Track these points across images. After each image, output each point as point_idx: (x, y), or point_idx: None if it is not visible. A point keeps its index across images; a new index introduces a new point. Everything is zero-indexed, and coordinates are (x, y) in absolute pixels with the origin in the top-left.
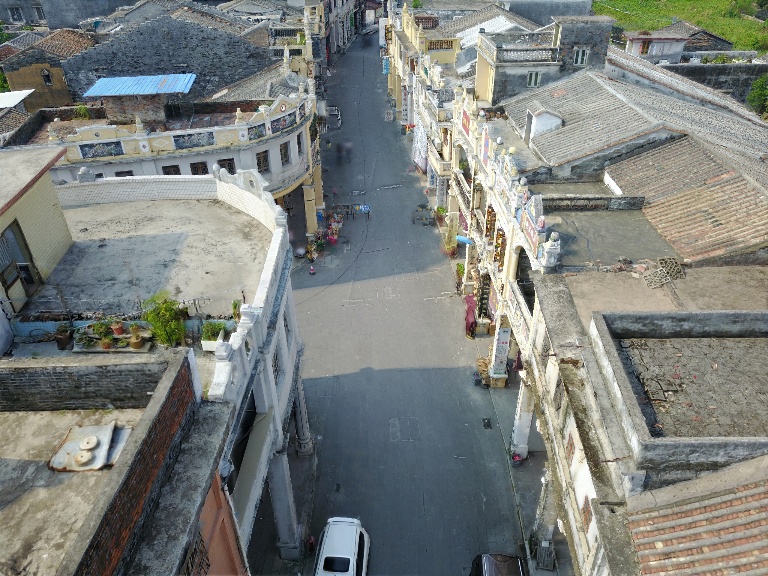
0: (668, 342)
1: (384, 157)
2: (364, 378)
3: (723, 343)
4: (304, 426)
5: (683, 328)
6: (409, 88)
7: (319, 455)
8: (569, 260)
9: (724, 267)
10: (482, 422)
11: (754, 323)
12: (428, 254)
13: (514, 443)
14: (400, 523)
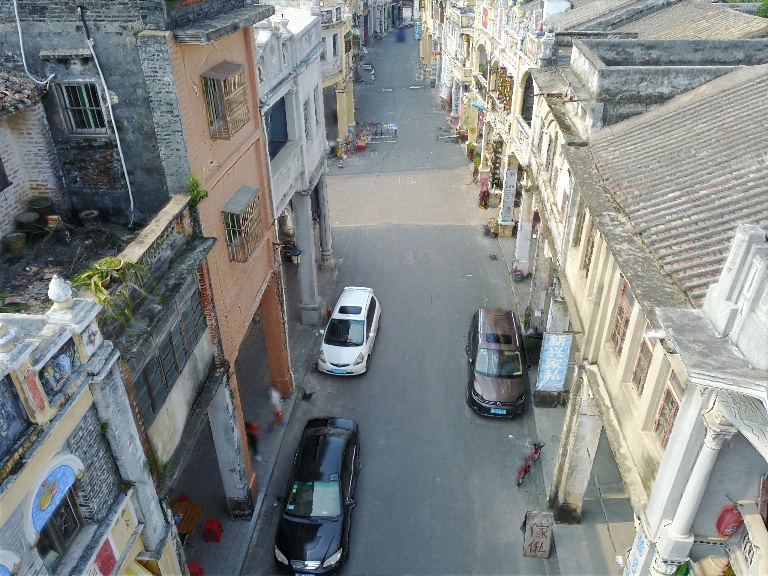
0: None
1: (413, 101)
2: (383, 228)
3: None
4: (327, 236)
5: (651, 57)
6: (438, 39)
7: (339, 270)
8: None
9: None
10: (489, 256)
11: (713, 52)
12: (449, 159)
13: (516, 259)
14: (409, 309)
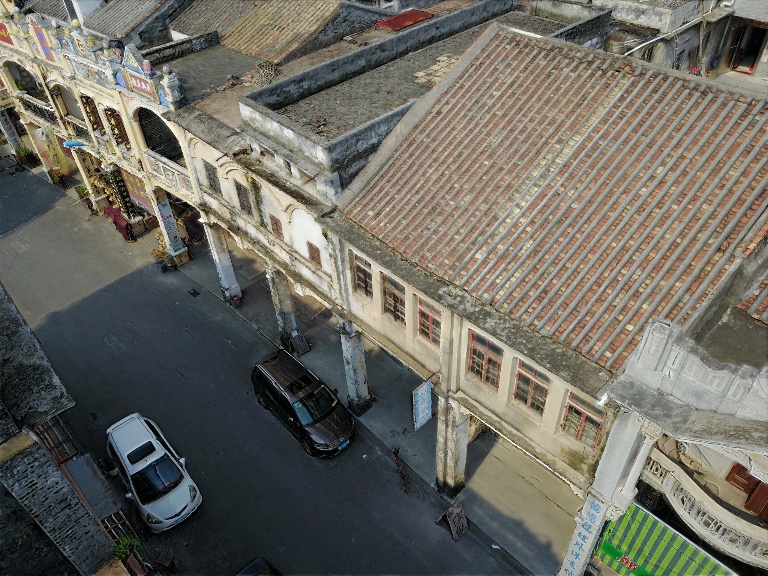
0: (300, 103)
1: None
2: (50, 324)
3: (334, 89)
4: None
5: (304, 88)
6: None
7: None
8: (189, 95)
9: (303, 57)
10: (189, 294)
11: (345, 67)
12: (36, 197)
13: (226, 288)
14: (173, 401)
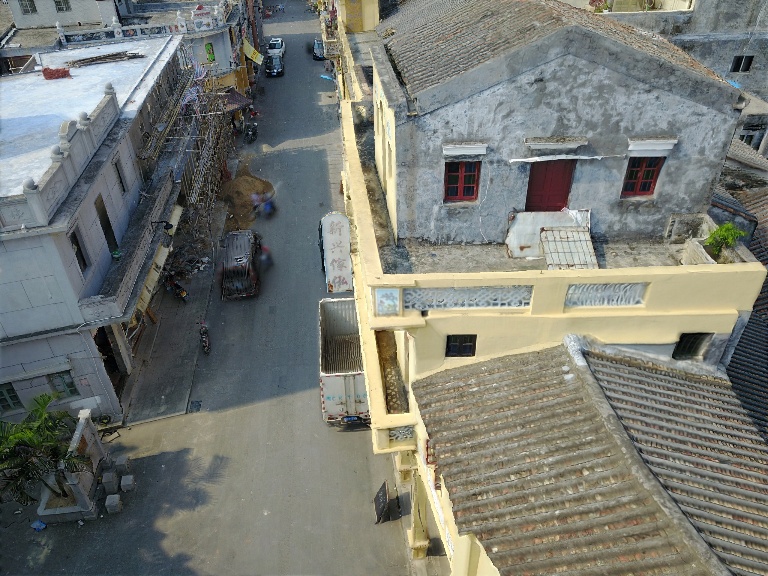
0: None
1: None
2: (283, 35)
3: None
4: None
5: None
6: None
7: None
8: None
9: None
10: None
11: None
12: None
13: None
14: None
